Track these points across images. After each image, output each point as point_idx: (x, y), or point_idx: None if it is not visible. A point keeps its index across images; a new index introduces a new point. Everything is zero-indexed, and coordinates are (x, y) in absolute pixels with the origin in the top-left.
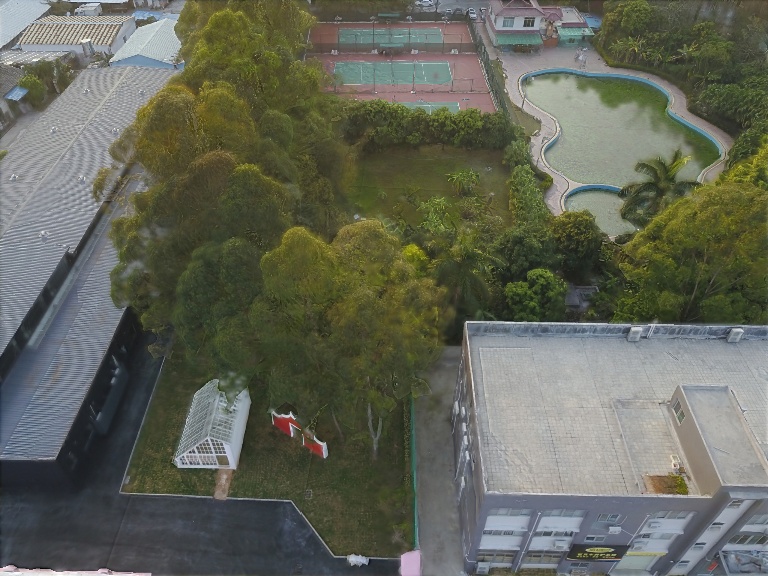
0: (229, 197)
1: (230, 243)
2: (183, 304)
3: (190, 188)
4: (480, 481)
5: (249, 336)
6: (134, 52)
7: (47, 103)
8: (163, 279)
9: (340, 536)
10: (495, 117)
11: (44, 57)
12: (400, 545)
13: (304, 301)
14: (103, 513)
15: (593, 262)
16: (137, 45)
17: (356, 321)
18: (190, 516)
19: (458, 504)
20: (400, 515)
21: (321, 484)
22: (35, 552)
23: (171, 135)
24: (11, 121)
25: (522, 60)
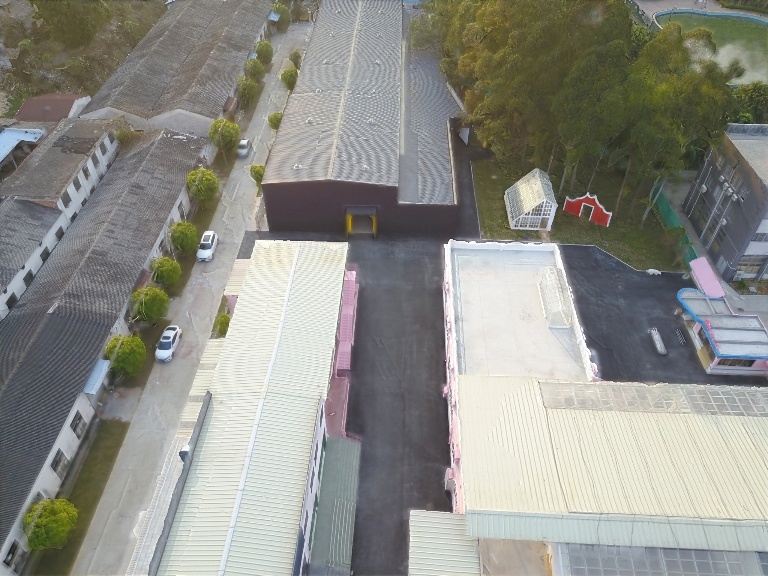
0: (610, 16)
1: (617, 41)
2: (573, 86)
3: (580, 13)
4: (761, 194)
5: (625, 99)
6: None
7: (285, 28)
8: (551, 76)
9: (636, 262)
10: (658, 33)
11: None
12: (678, 266)
13: (670, 71)
14: None
15: (764, 122)
16: None
17: (704, 81)
18: None
19: (707, 250)
20: (675, 250)
21: (611, 239)
22: None
23: None
24: (268, 38)
25: (651, 3)
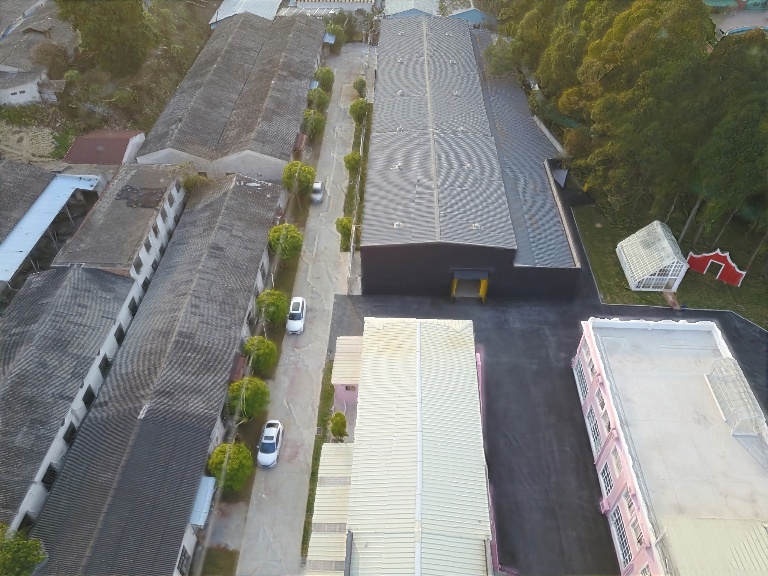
0: None
1: None
2: (728, 138)
3: (737, 54)
4: None
5: None
6: (407, 7)
7: (338, 49)
8: (698, 125)
9: None
10: None
11: (326, 12)
12: None
13: None
14: (599, 315)
15: None
16: (405, 2)
17: None
18: (663, 318)
19: None
20: None
21: (746, 302)
22: (568, 335)
23: (687, 25)
24: None
25: (720, 19)
